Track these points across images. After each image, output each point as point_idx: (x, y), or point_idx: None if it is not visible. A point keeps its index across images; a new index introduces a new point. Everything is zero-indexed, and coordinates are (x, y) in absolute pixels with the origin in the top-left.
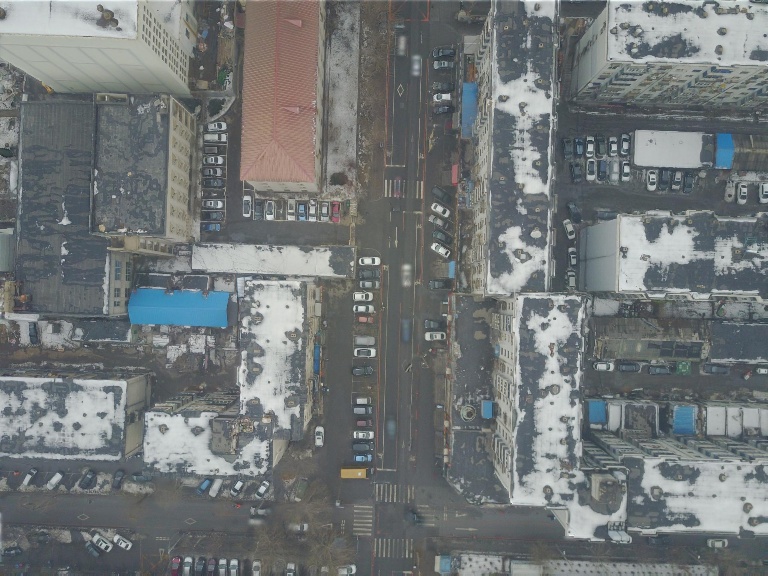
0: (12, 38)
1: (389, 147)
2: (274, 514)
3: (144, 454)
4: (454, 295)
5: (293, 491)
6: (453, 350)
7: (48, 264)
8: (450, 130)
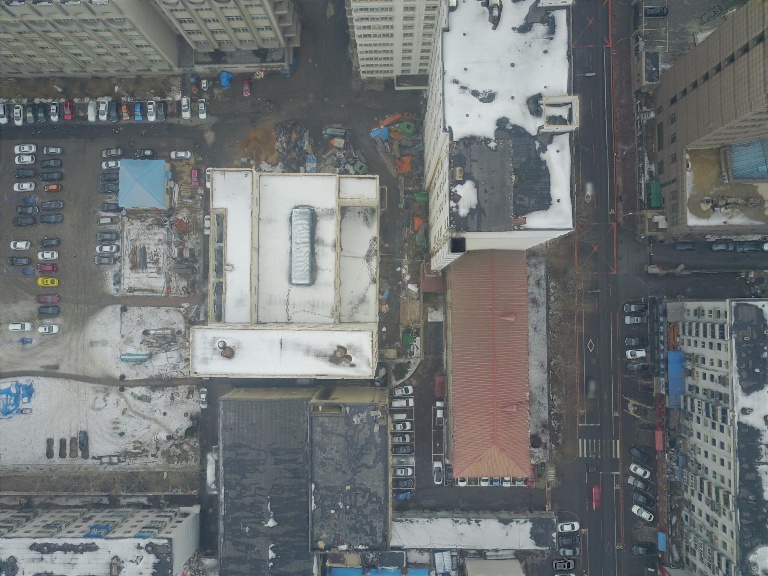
0: None
1: (582, 405)
2: None
3: None
4: None
5: None
6: None
7: (255, 568)
8: (646, 387)
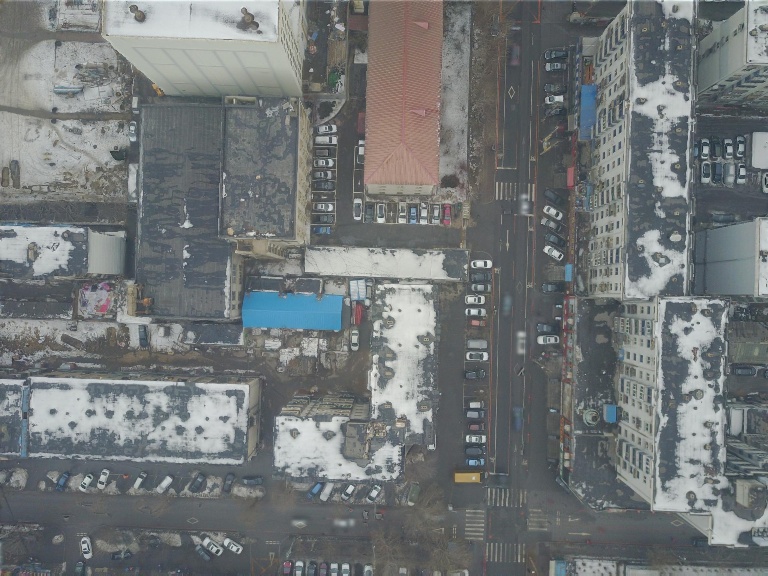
0: (151, 41)
1: (500, 149)
2: (390, 518)
3: (275, 458)
4: (576, 299)
5: (404, 495)
6: (575, 354)
7: (170, 267)
8: (562, 132)
